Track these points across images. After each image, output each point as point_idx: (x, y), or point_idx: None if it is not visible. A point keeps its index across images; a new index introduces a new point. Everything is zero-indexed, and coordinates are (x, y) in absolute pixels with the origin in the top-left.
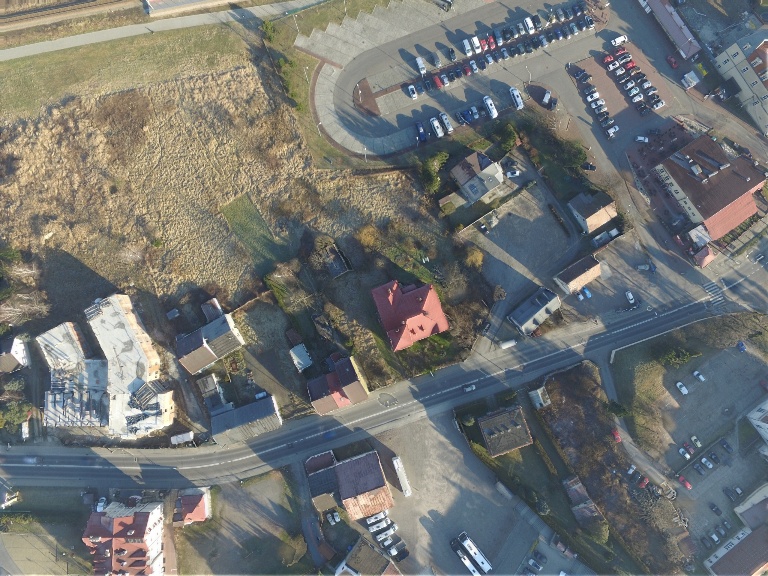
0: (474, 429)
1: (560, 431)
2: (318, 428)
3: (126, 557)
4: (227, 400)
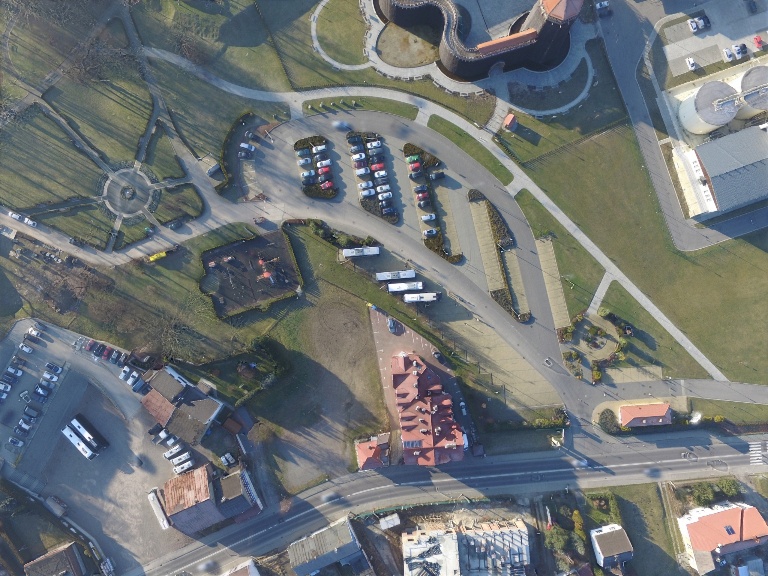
0: (91, 562)
1: (1, 572)
2: (254, 542)
3: (420, 426)
4: (348, 564)
